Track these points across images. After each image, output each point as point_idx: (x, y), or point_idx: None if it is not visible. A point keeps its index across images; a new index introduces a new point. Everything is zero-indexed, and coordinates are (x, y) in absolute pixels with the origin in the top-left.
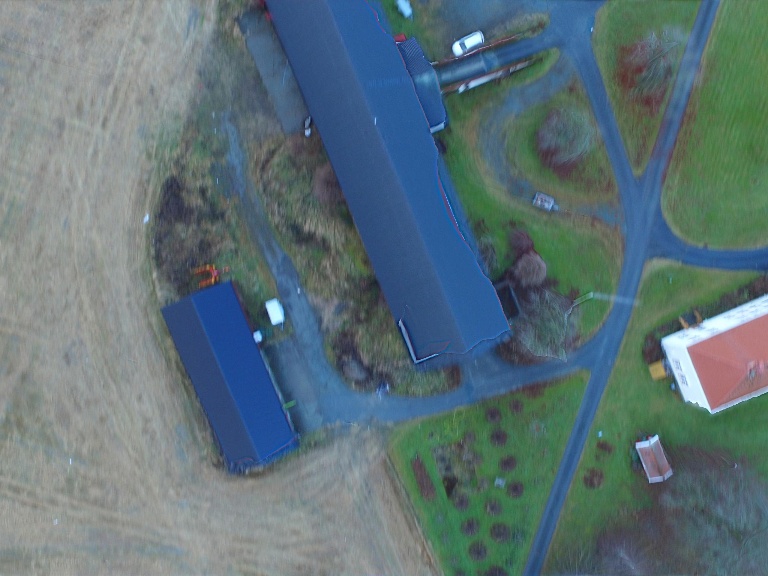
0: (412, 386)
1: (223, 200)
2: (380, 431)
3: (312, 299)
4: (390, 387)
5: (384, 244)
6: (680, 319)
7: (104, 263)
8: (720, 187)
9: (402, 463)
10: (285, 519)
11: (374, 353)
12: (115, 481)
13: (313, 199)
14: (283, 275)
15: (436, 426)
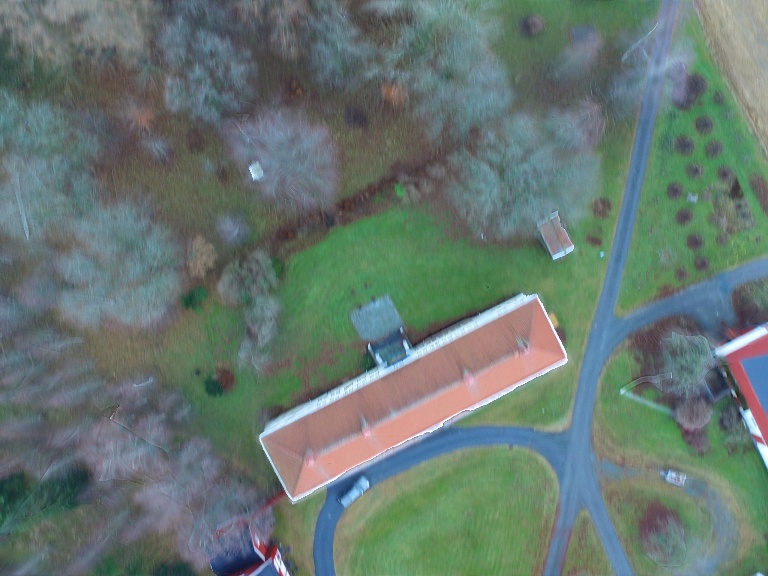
0: None
1: None
2: None
3: None
4: None
5: None
6: None
7: None
8: (503, 506)
9: None
10: None
11: None
12: None
13: None
14: None
15: (754, 249)
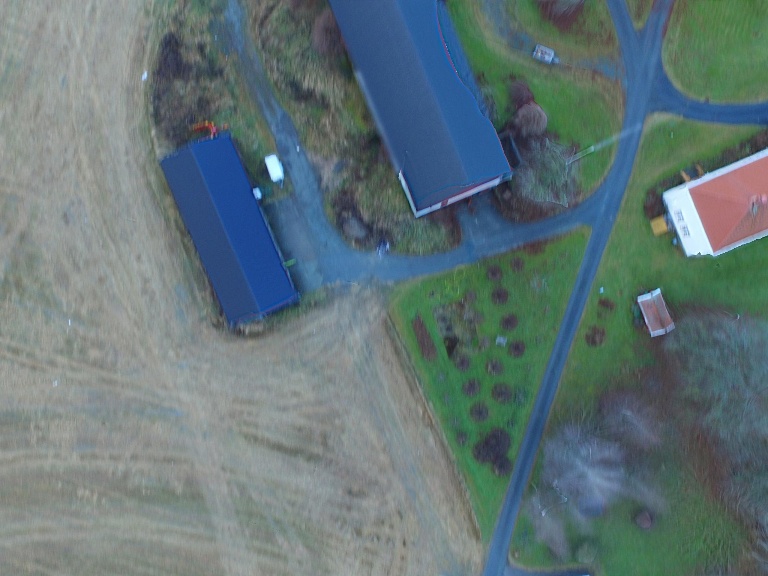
0: (412, 243)
1: (222, 57)
2: (380, 290)
3: (311, 157)
4: (390, 245)
5: (383, 86)
6: (682, 173)
7: (102, 121)
8: (721, 40)
9: (403, 323)
10: (285, 380)
11: (374, 209)
12: (114, 342)
13: (312, 53)
14: (282, 133)
15: (437, 285)
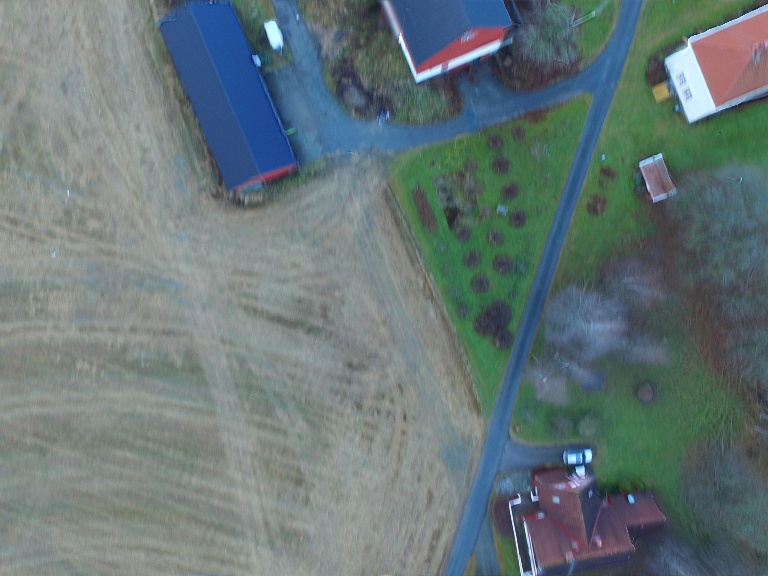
0: (413, 111)
1: None
2: (380, 160)
3: (311, 26)
4: (390, 114)
5: None
6: (684, 38)
7: None
8: None
9: (403, 193)
10: (285, 252)
11: (374, 75)
12: (113, 213)
13: None
14: (282, 1)
15: (437, 155)
